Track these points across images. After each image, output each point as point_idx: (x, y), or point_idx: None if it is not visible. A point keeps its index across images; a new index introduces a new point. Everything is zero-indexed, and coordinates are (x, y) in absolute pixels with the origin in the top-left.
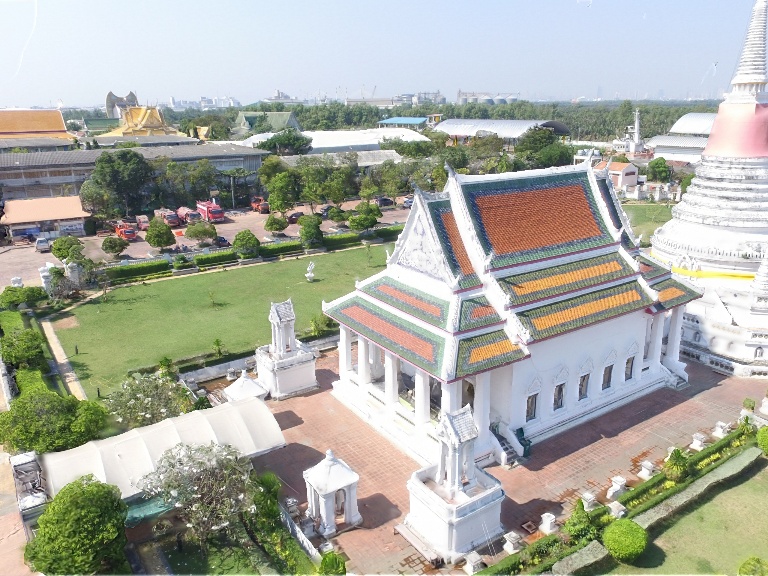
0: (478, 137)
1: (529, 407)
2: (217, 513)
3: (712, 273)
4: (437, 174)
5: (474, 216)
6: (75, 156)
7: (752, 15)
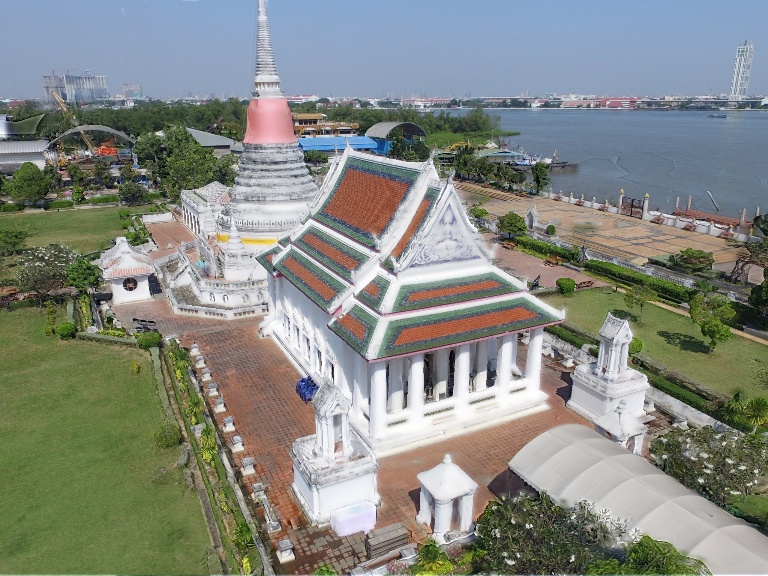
0: None
1: None
2: (758, 442)
3: None
4: None
5: None
6: None
7: (261, 25)
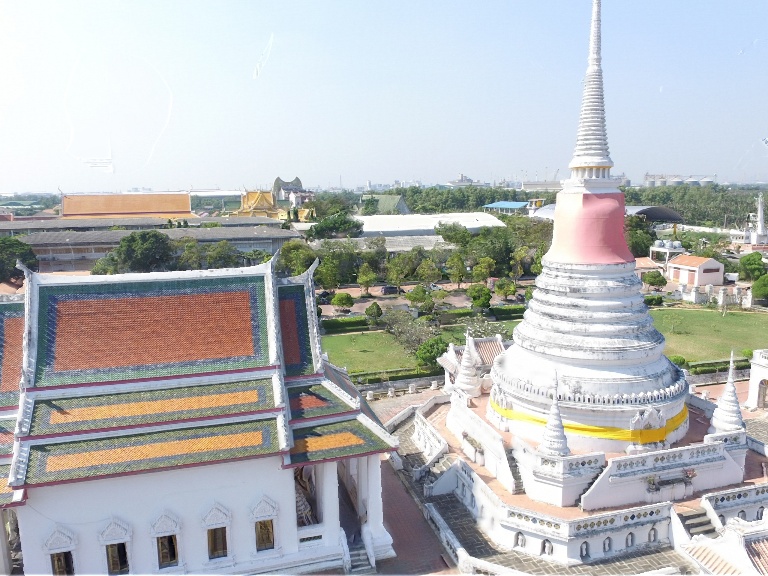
0: (533, 224)
1: (63, 567)
2: None
3: (521, 414)
4: (451, 263)
5: (46, 323)
6: (119, 235)
7: None
